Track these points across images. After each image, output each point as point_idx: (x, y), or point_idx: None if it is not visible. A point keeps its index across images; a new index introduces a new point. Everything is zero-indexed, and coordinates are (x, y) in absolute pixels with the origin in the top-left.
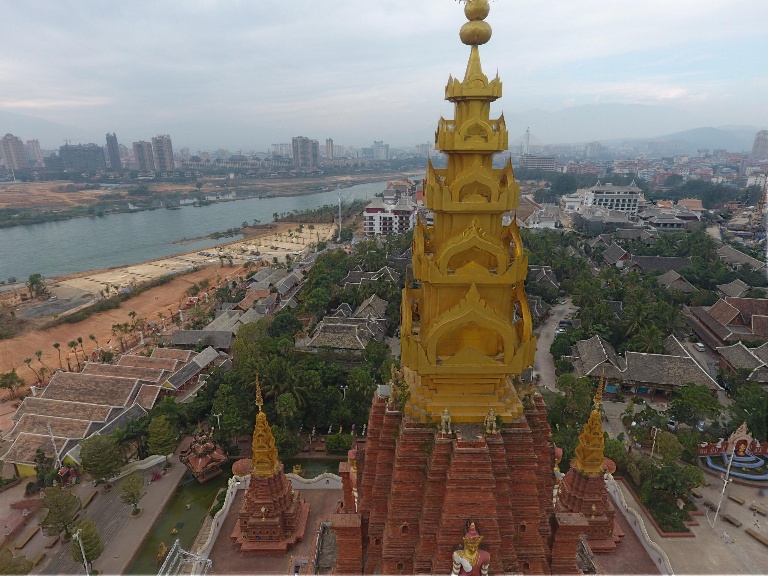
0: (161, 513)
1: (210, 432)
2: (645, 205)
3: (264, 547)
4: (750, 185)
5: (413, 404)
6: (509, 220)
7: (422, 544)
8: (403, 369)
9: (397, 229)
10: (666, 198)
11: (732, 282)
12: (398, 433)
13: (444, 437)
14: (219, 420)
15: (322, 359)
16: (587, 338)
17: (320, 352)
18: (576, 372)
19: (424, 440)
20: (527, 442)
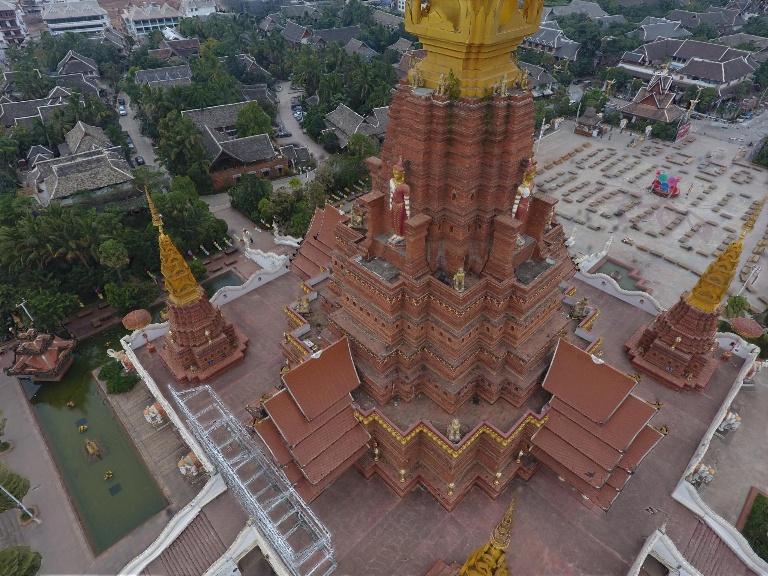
0: (41, 428)
1: (4, 338)
2: None
3: (222, 365)
4: None
5: (464, 87)
6: (160, 10)
7: (490, 198)
8: (410, 77)
9: (4, 42)
10: None
11: (398, 41)
12: (453, 120)
13: (503, 101)
14: (26, 310)
15: (88, 206)
16: (332, 110)
17: (78, 200)
18: (342, 140)
19: (484, 112)
20: (532, 96)
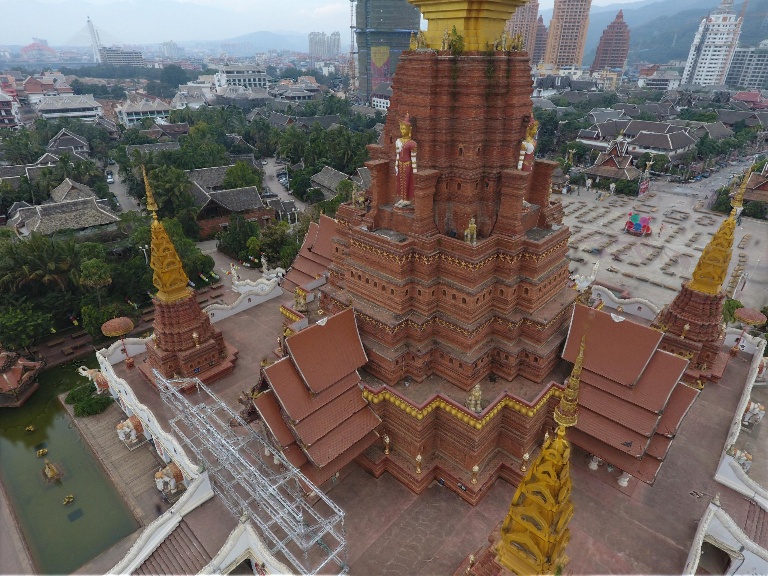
0: None
1: None
2: (274, 83)
3: (209, 374)
4: (343, 62)
5: None
6: (152, 104)
7: (496, 153)
8: (413, 45)
9: None
10: (288, 76)
11: (375, 126)
12: (457, 75)
13: (504, 55)
14: None
15: None
16: (317, 173)
17: (60, 237)
18: (327, 196)
19: (486, 66)
20: None
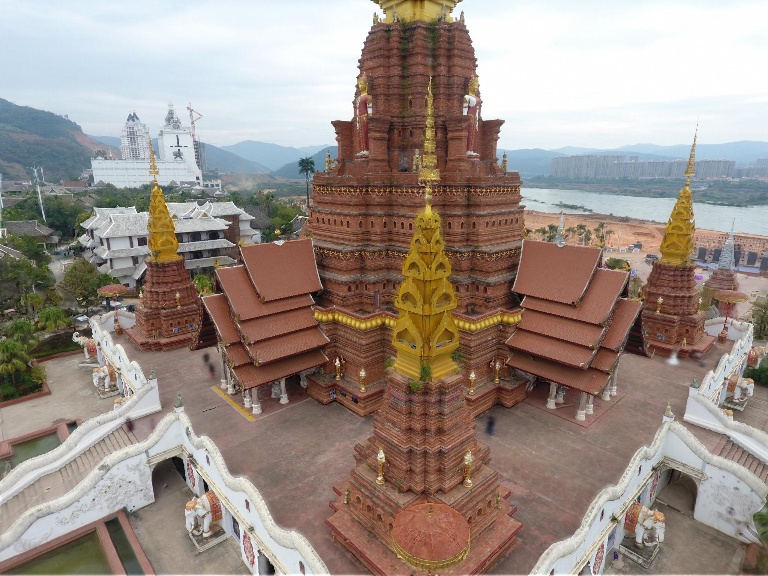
0: None
1: None
2: None
3: None
4: None
5: None
6: None
7: None
8: None
9: None
10: None
11: None
12: None
13: None
14: None
15: None
16: None
17: None
18: None
19: None
20: None
